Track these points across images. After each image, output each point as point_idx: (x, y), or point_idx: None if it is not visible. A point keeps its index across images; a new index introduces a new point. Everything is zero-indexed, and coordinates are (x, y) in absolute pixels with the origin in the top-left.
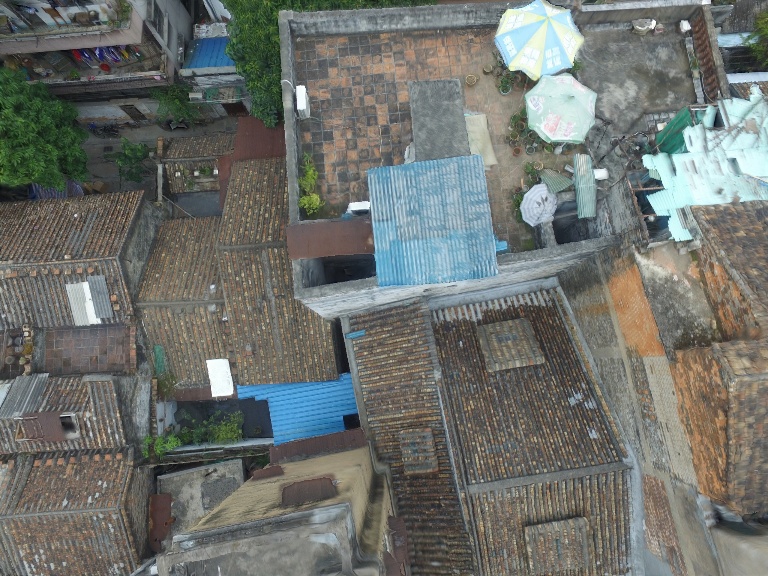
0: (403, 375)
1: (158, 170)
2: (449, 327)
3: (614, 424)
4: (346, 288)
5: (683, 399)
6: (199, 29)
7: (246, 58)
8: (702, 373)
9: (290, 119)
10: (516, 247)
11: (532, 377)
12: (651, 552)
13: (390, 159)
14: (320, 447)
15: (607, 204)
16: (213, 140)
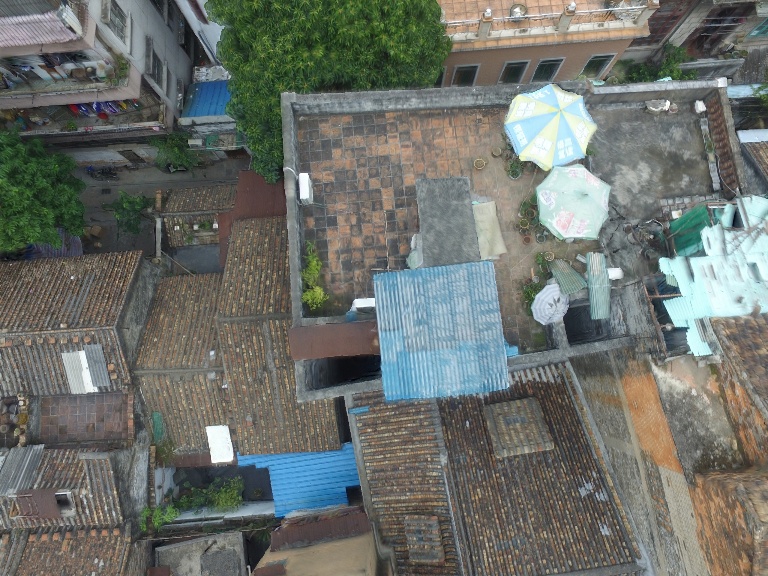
0: (408, 456)
1: (157, 224)
2: (455, 404)
3: (626, 519)
4: (351, 391)
5: (703, 525)
6: (199, 72)
7: (247, 118)
8: (724, 509)
9: (293, 209)
10: (526, 341)
11: (541, 463)
12: None
13: (396, 246)
14: (323, 532)
15: (621, 302)
16: (213, 192)
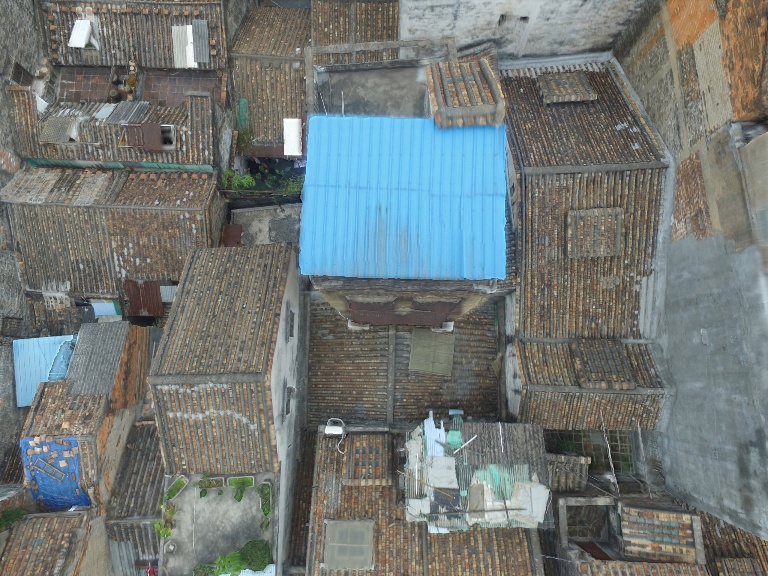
0: None
1: None
2: (511, 80)
3: (655, 140)
4: None
5: (729, 43)
6: None
7: None
8: None
9: None
10: None
11: (584, 112)
12: (676, 240)
13: None
14: None
15: None
16: None
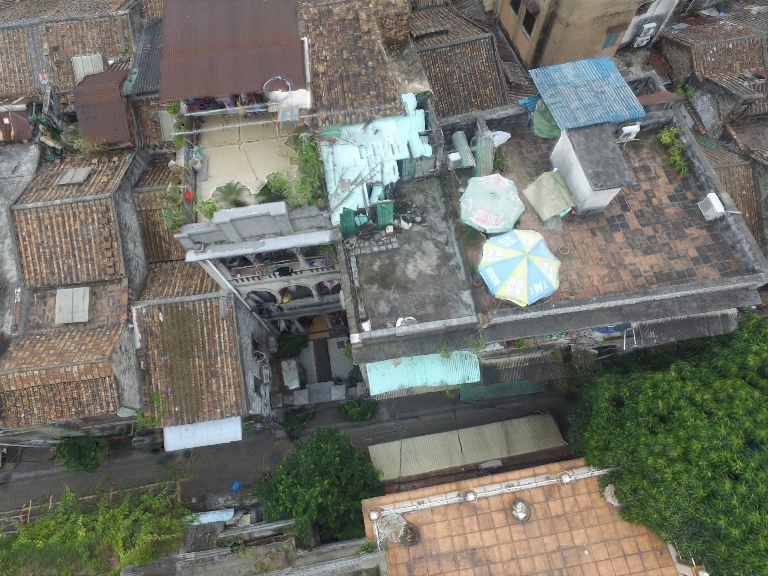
0: None
1: None
2: None
3: None
4: None
5: None
6: None
7: None
8: None
9: (717, 184)
10: None
11: (447, 113)
12: None
13: None
14: None
15: None
16: None
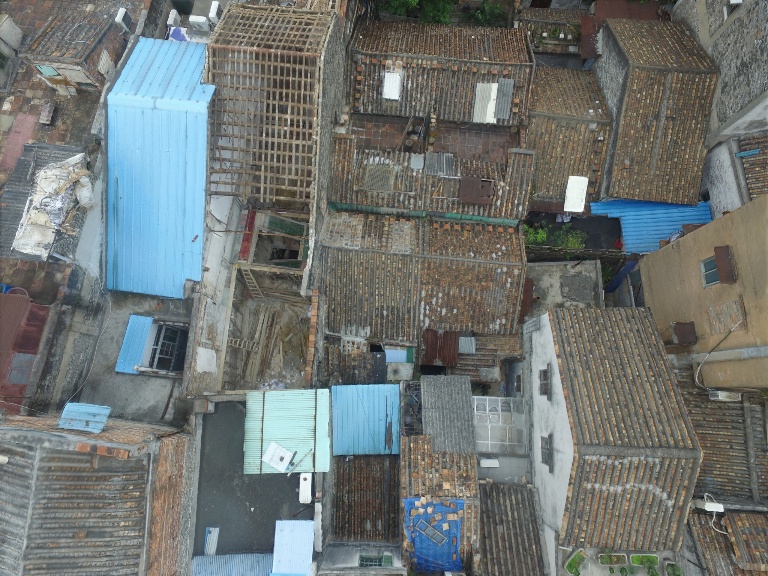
0: None
1: (515, 25)
2: None
3: None
4: None
5: None
6: None
7: None
8: None
9: None
10: None
11: None
12: None
13: None
14: None
15: None
16: (557, 12)
